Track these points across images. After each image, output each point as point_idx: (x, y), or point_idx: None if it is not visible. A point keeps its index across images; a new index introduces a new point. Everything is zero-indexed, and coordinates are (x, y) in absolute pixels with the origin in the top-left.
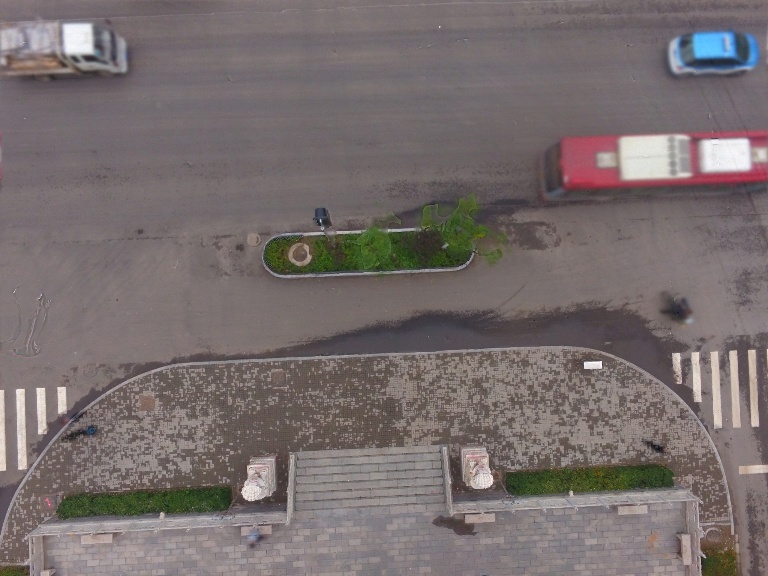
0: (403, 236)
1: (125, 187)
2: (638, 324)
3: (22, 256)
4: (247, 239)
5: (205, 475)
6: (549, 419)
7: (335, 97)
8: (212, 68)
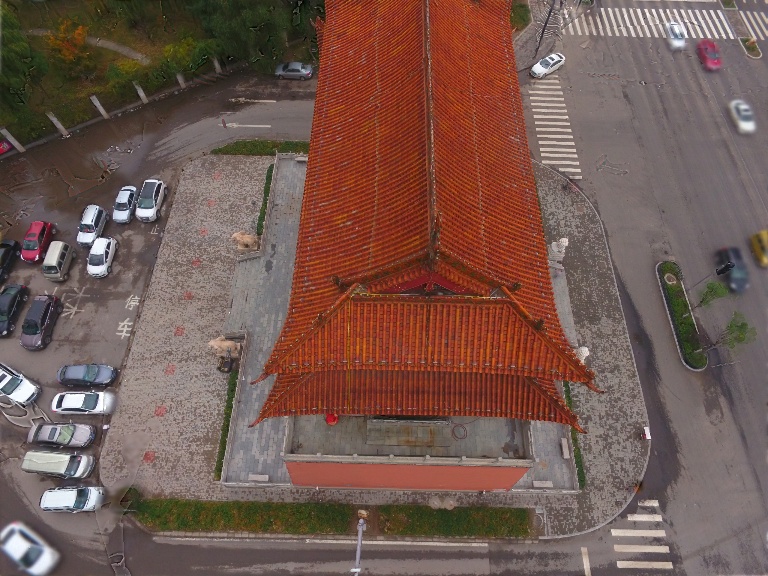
0: (695, 330)
1: (683, 207)
2: (673, 475)
3: (640, 167)
4: (671, 256)
5: (548, 230)
6: (602, 409)
7: (760, 302)
8: (755, 246)
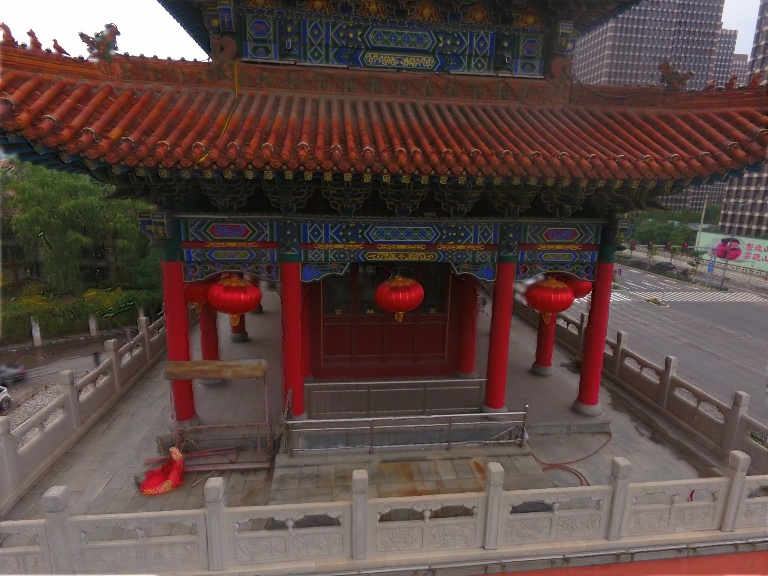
0: None
1: None
2: None
3: None
4: None
5: None
6: None
7: None
8: None
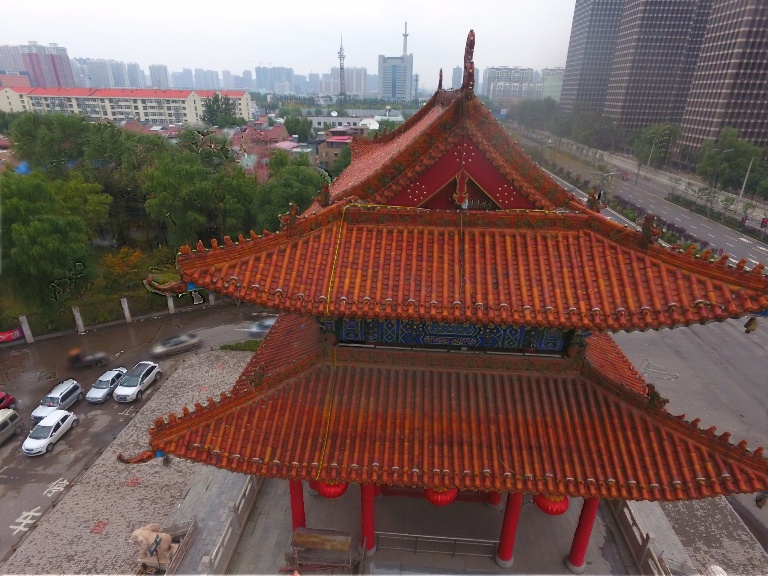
0: None
1: (765, 412)
2: None
3: (691, 375)
4: None
5: None
6: None
7: None
8: None
